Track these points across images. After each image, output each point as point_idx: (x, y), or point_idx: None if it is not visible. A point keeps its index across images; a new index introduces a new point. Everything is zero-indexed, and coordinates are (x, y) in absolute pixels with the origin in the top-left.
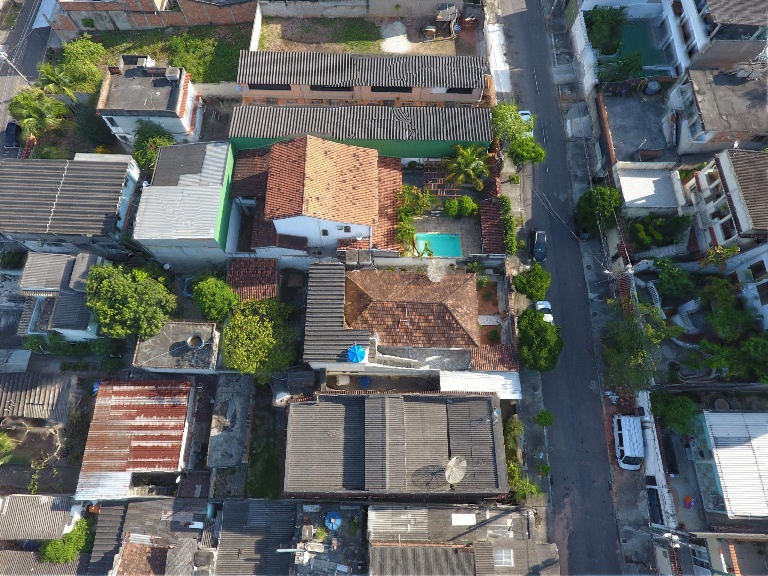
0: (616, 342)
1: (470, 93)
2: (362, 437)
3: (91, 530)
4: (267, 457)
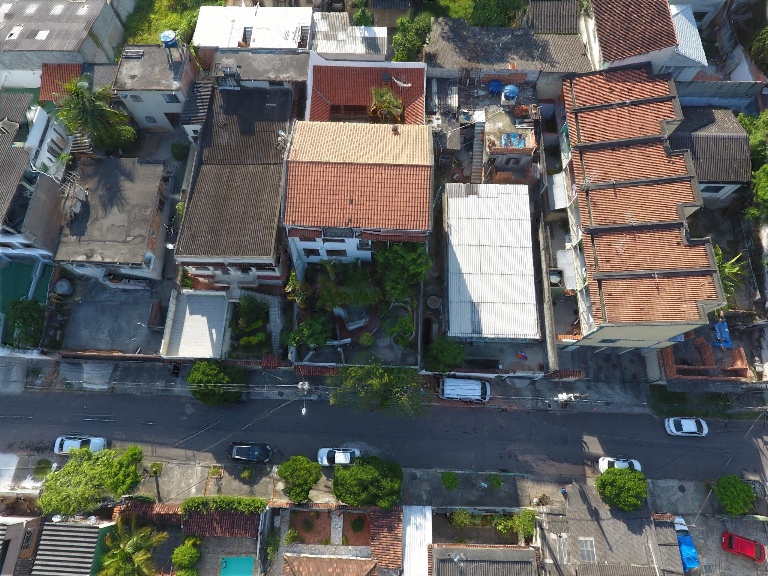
0: None
1: (8, 542)
2: None
3: None
4: None
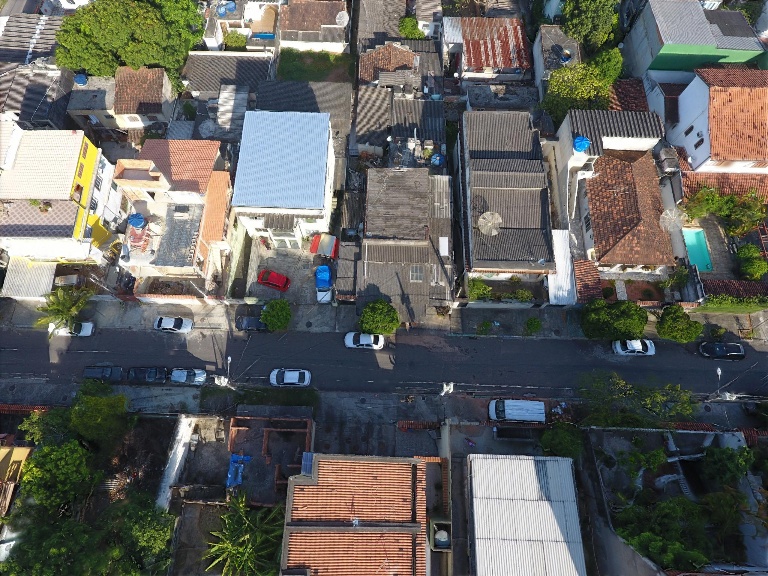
0: (624, 412)
1: None
2: None
3: None
4: None
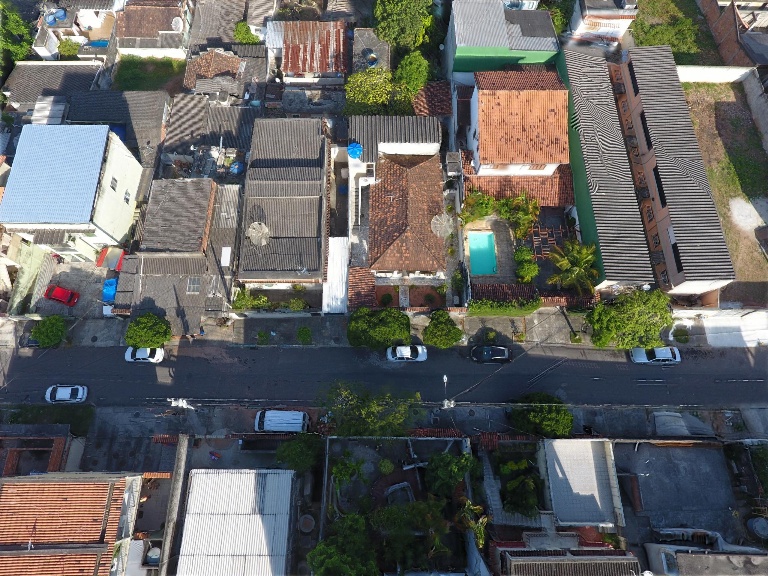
0: None
1: (679, 271)
2: None
3: None
4: None
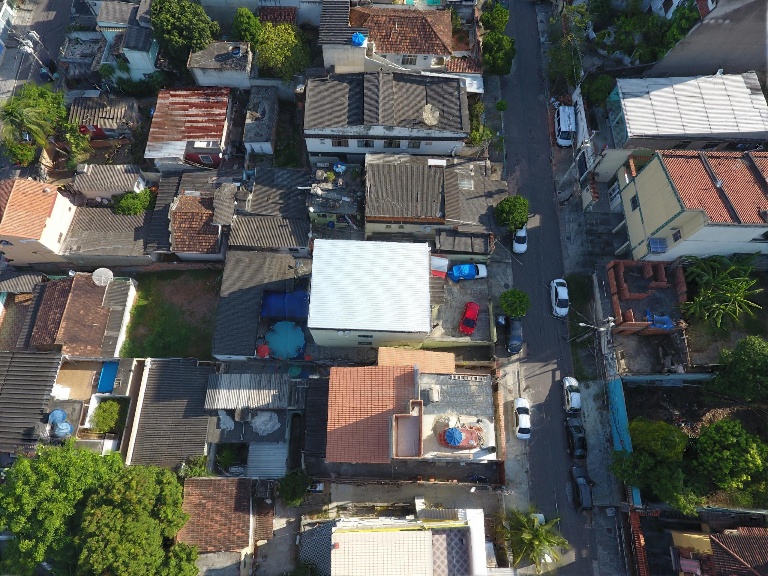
0: None
1: None
2: None
3: (153, 195)
4: (288, 153)
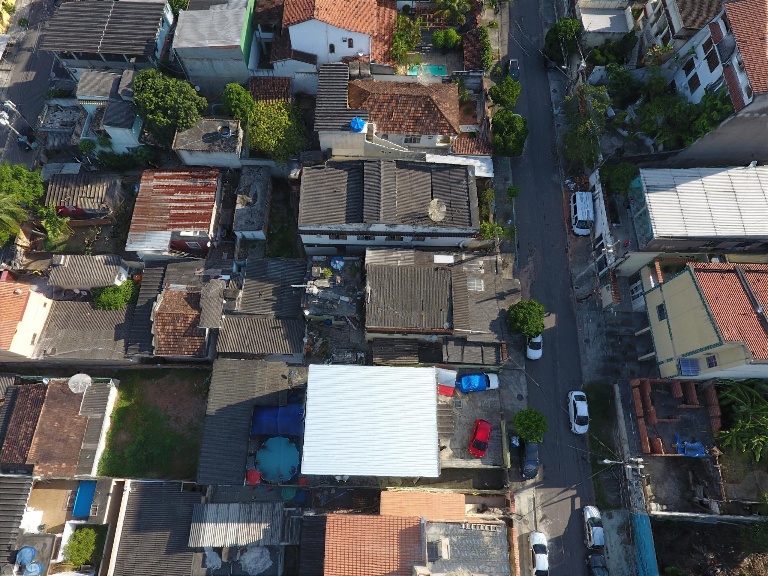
0: None
1: None
2: (361, 190)
3: (136, 287)
4: (282, 237)
